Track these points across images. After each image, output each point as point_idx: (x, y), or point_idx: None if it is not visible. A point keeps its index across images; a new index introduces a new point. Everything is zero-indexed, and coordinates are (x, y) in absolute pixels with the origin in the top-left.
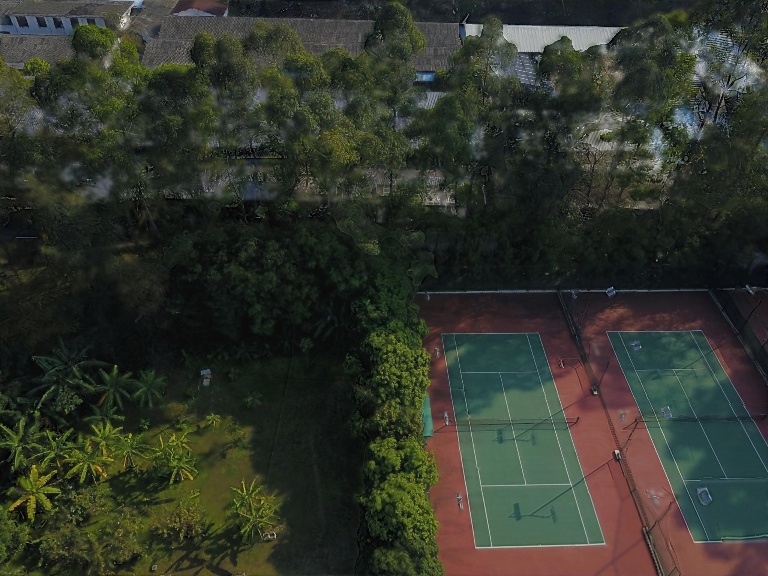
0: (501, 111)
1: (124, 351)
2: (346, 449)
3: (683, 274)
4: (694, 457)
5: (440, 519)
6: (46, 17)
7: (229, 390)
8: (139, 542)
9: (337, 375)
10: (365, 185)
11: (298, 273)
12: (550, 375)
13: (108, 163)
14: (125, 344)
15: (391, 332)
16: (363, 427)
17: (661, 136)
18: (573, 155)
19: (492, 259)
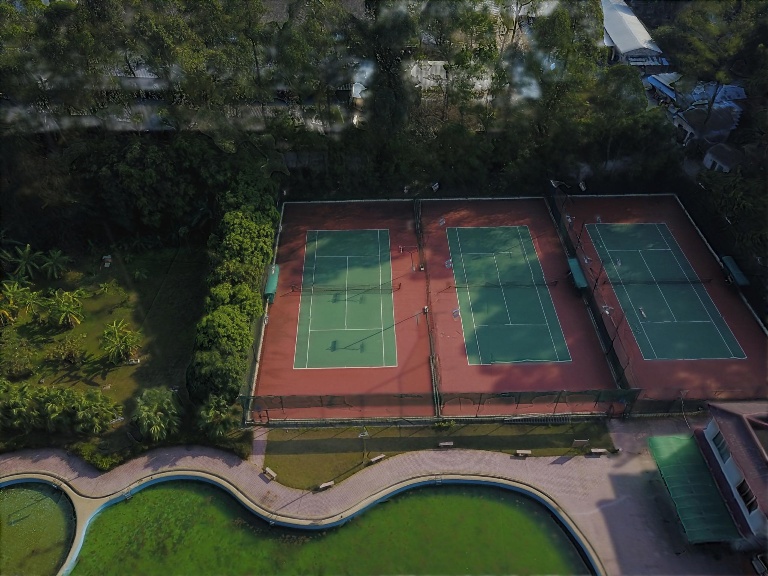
0: (336, 37)
1: (40, 239)
2: None
3: (525, 186)
4: (489, 311)
5: (270, 351)
6: None
7: (124, 270)
8: (32, 363)
9: None
10: (238, 106)
11: (177, 173)
12: (389, 258)
13: (7, 72)
14: (41, 233)
15: (242, 212)
16: None
17: (472, 57)
18: (409, 78)
19: (358, 173)
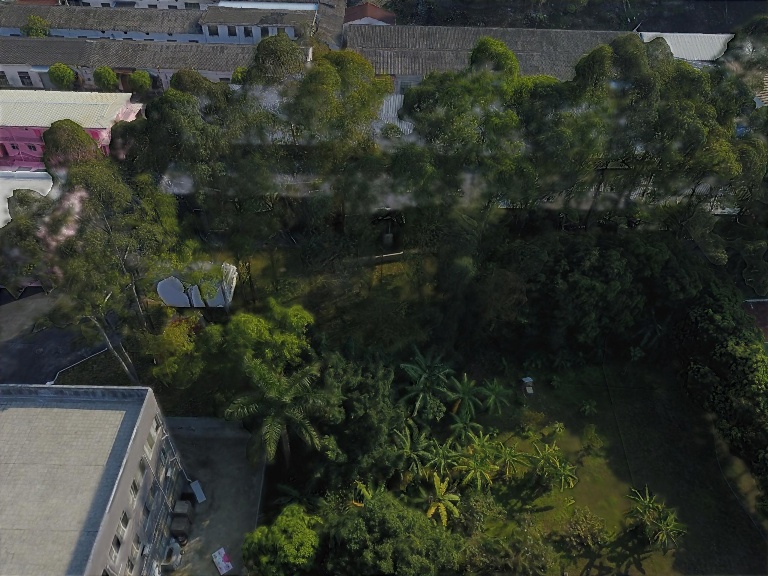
0: None
1: None
2: (698, 457)
3: None
4: None
5: None
6: (238, 26)
7: (555, 398)
8: None
9: (654, 383)
10: (675, 195)
11: None
12: None
13: (517, 174)
14: None
15: (747, 341)
16: (742, 436)
17: None
18: None
19: None
